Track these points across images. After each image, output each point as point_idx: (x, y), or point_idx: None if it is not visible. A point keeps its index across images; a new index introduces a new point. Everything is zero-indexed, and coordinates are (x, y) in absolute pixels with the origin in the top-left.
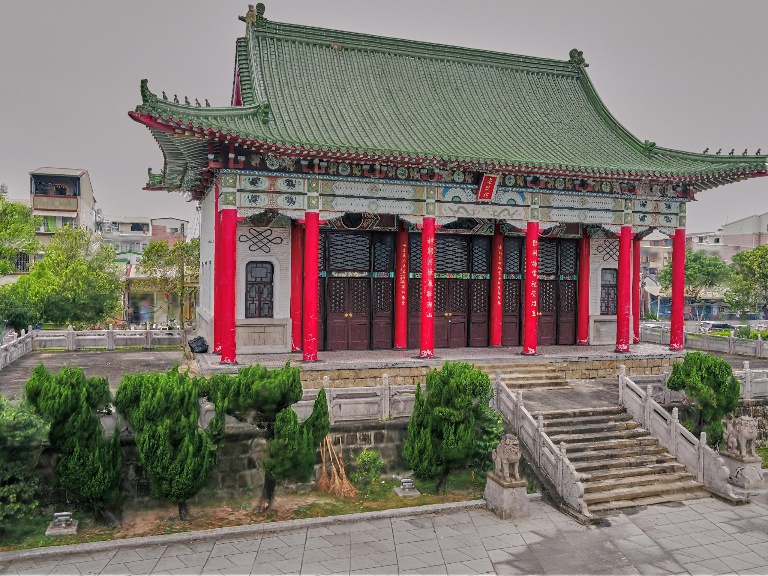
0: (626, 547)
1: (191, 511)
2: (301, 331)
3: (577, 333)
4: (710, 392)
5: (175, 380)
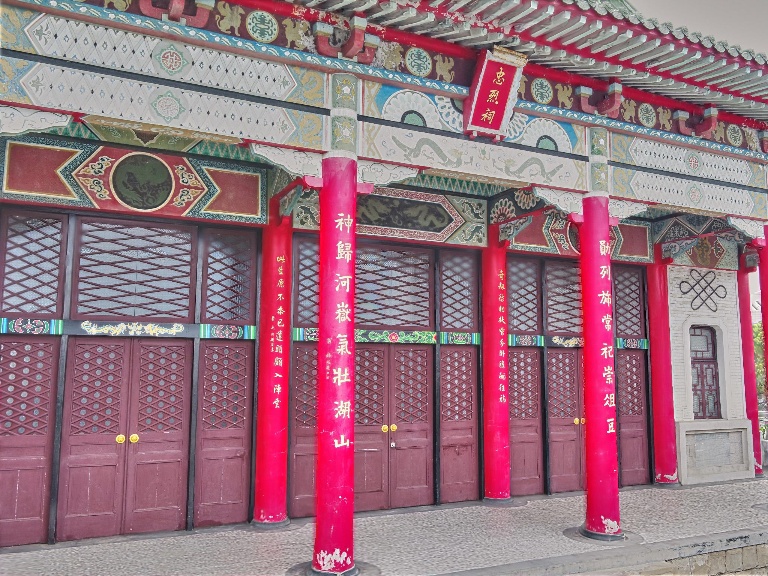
0: None
1: None
2: None
3: (654, 460)
4: None
5: None
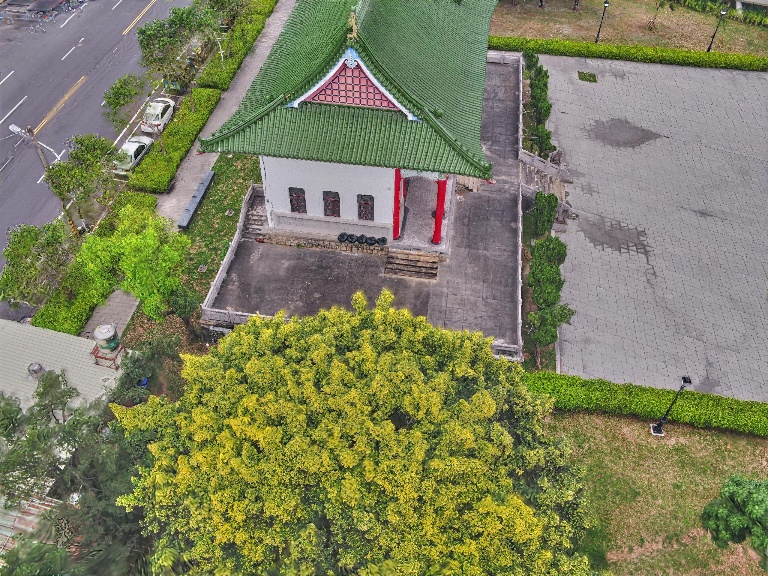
0: (593, 220)
1: (530, 296)
2: None
3: None
4: None
5: None
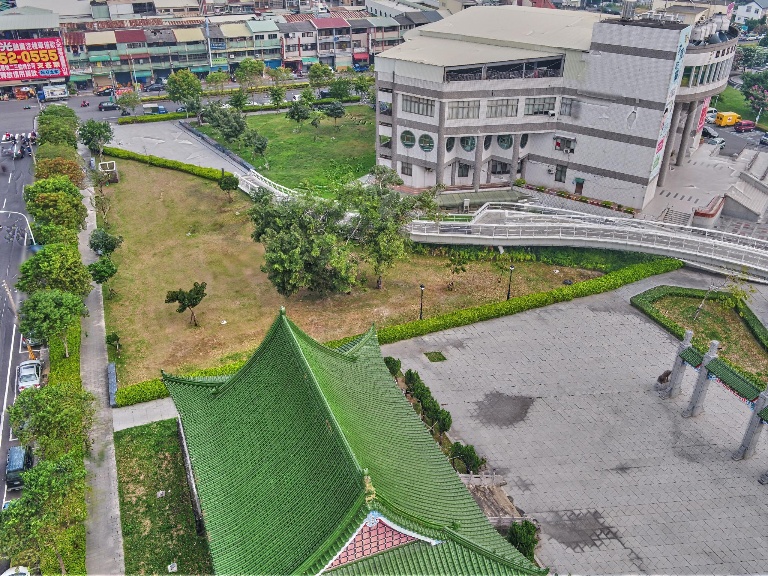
0: None
1: None
2: None
3: None
4: None
5: None
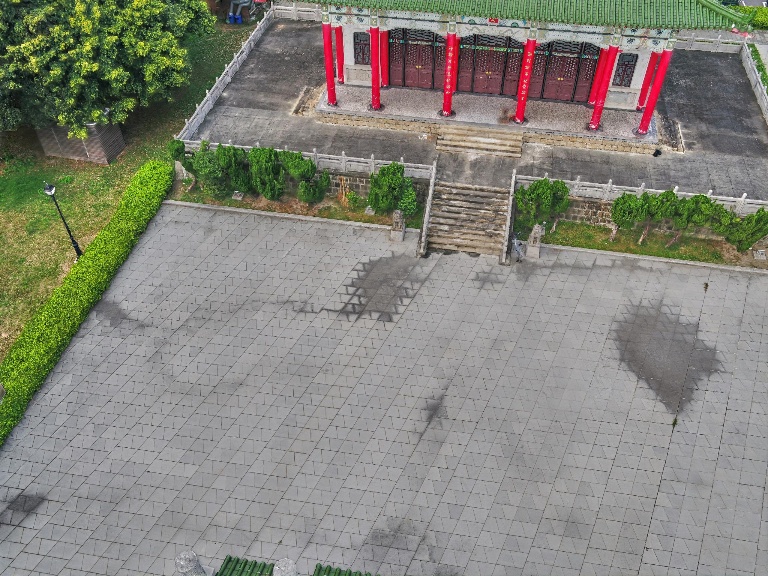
0: (415, 271)
1: (284, 197)
2: (388, 74)
3: (589, 96)
4: (532, 207)
5: (264, 160)
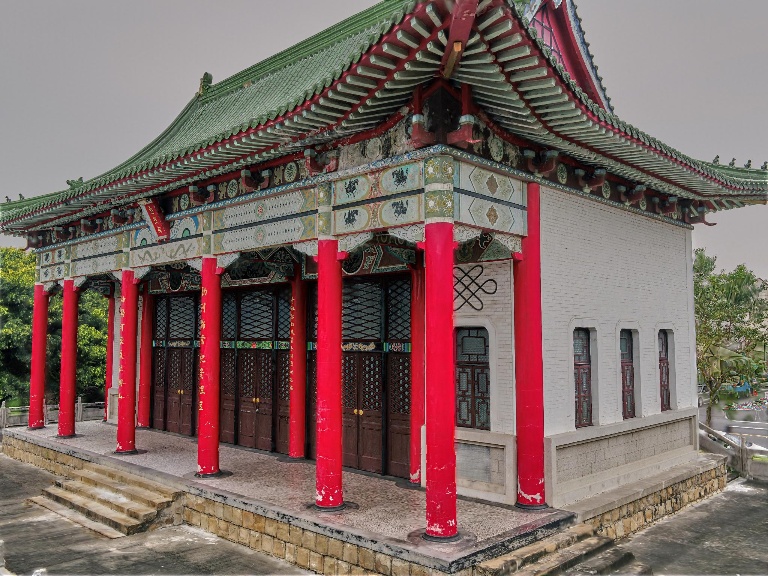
0: None
1: None
2: (149, 406)
3: None
4: None
5: None
